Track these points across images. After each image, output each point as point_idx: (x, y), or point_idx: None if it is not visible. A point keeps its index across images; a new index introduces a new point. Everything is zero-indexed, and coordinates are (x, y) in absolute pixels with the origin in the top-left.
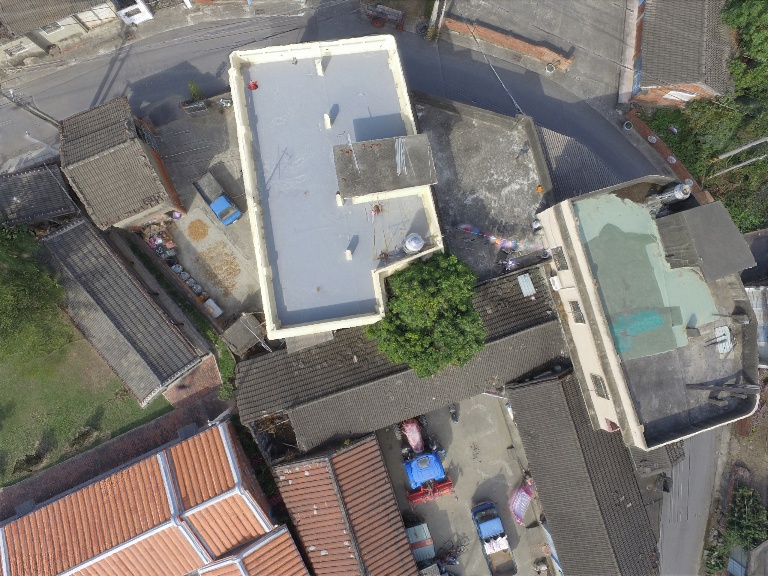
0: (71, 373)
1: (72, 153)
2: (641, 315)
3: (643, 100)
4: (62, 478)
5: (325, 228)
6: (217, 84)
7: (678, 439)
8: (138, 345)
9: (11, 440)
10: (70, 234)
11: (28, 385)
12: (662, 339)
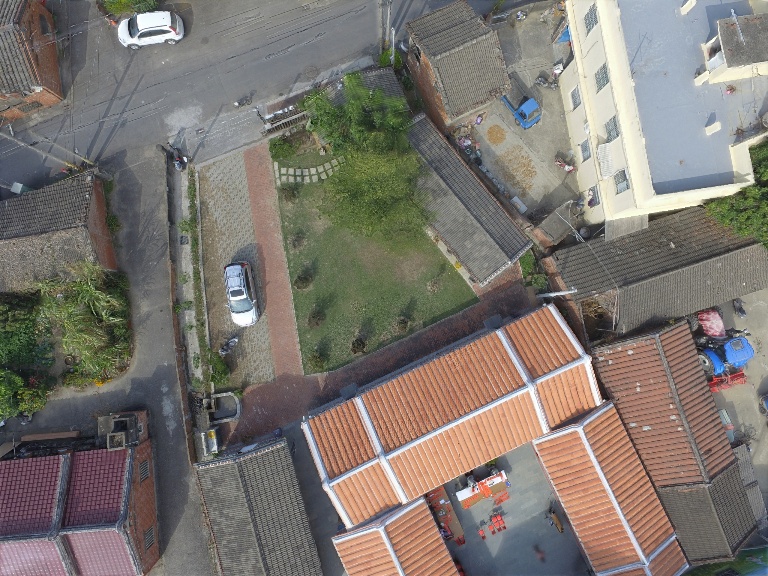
0: (386, 267)
1: (434, 46)
2: None
3: None
4: (380, 364)
5: (685, 106)
6: (506, 1)
7: None
8: (485, 226)
9: (334, 328)
10: (417, 126)
11: (348, 277)
12: None
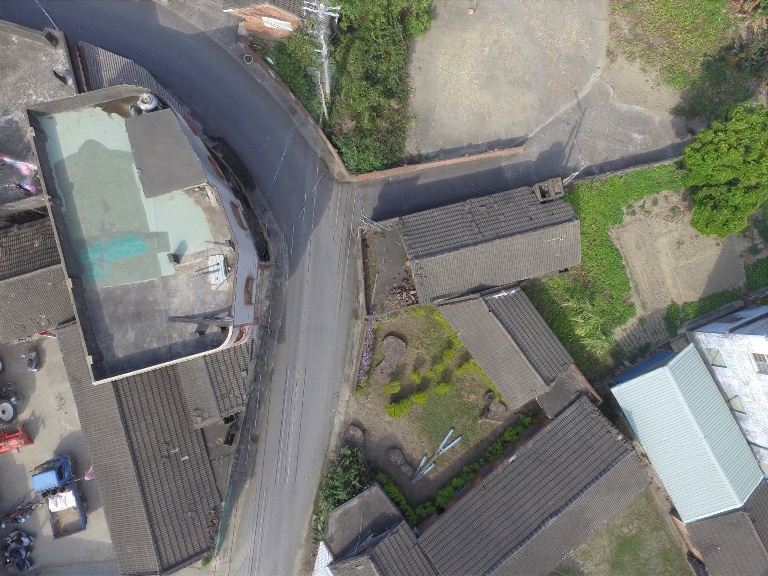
0: None
1: None
2: (122, 240)
3: (256, 31)
4: None
5: None
6: None
7: (131, 373)
8: None
9: None
10: None
11: None
12: (144, 266)
